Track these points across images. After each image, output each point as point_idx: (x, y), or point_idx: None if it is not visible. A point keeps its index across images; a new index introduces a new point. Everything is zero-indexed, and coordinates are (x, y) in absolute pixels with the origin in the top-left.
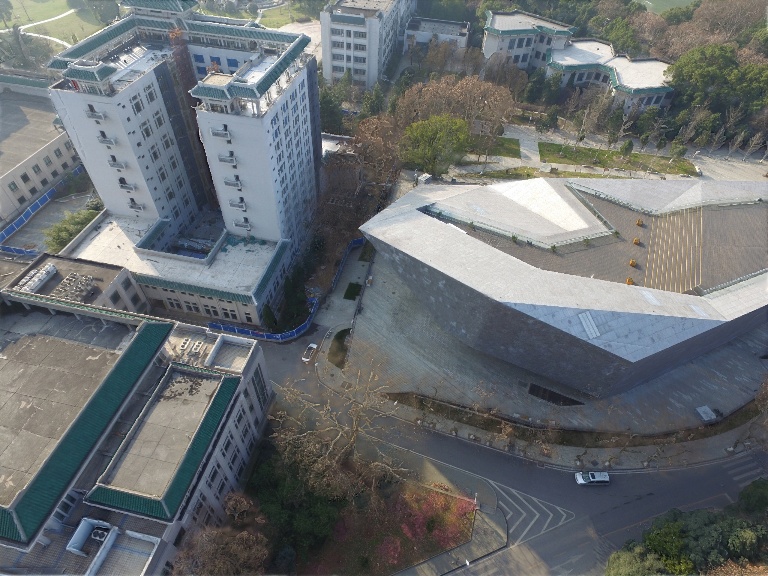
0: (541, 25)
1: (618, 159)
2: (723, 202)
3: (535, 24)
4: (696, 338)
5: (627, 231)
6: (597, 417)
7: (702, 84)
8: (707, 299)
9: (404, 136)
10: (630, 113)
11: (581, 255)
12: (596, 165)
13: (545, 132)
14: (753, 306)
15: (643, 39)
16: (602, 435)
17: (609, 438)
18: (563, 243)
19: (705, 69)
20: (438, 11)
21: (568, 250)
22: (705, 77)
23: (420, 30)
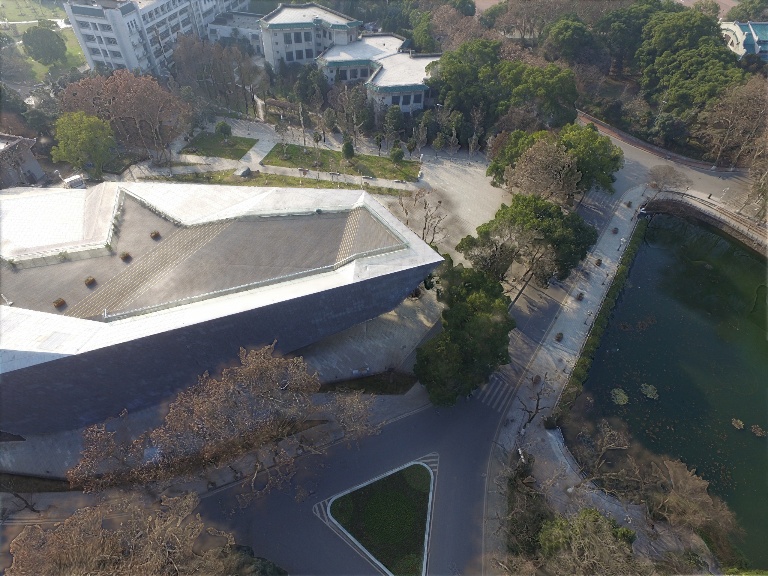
0: (323, 19)
1: (343, 162)
2: (271, 212)
3: (319, 17)
4: (38, 373)
5: (130, 244)
6: (26, 456)
7: (452, 82)
8: (106, 326)
9: (58, 134)
10: (378, 113)
11: (41, 270)
12: (314, 168)
13: (282, 132)
14: (132, 336)
15: (441, 34)
16: (16, 478)
17: (23, 481)
18: (36, 256)
19: (453, 65)
20: (255, 5)
21: (32, 264)
22: (453, 74)
23: (227, 24)
